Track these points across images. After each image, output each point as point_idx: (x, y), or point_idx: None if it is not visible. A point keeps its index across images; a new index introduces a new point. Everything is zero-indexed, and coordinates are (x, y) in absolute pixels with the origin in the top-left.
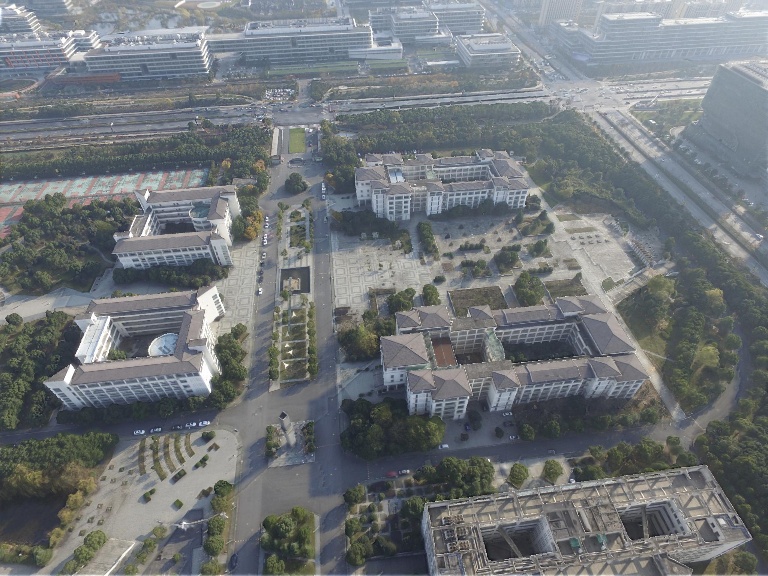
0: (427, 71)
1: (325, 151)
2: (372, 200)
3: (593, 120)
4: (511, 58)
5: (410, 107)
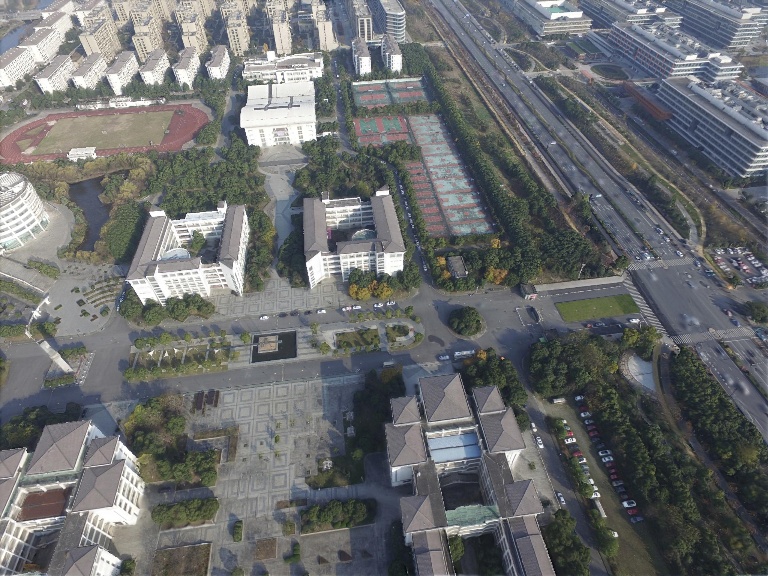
0: None
1: None
2: None
3: None
4: None
5: None
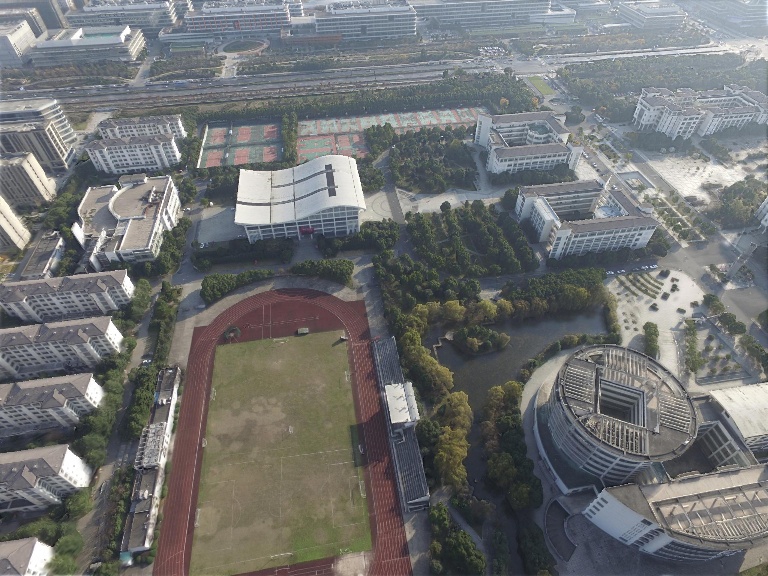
0: (605, 32)
1: (583, 91)
2: (662, 123)
3: None
4: (678, 20)
5: (615, 60)
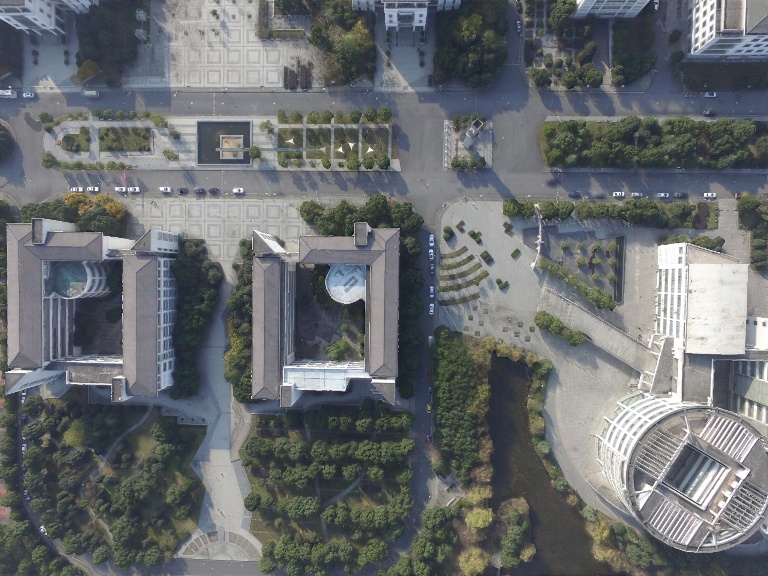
0: None
1: None
2: None
3: None
4: None
5: None
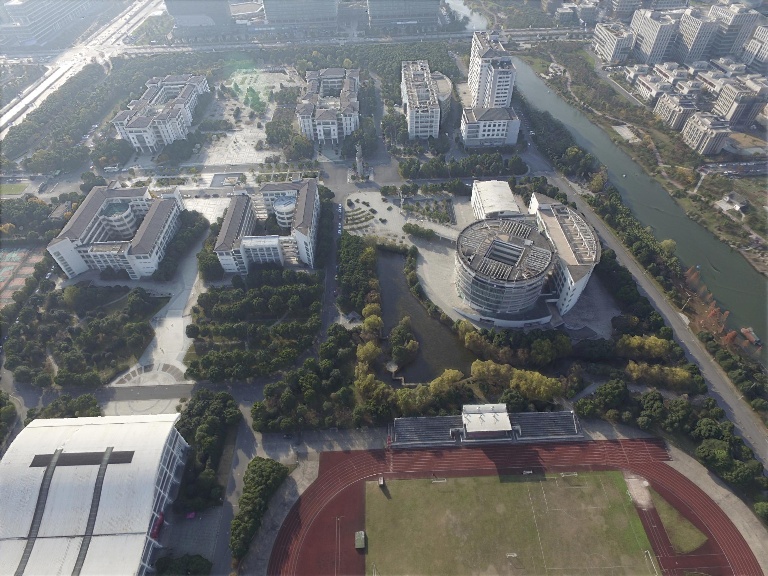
0: None
1: (55, 161)
2: (165, 134)
3: (131, 56)
4: None
5: None
